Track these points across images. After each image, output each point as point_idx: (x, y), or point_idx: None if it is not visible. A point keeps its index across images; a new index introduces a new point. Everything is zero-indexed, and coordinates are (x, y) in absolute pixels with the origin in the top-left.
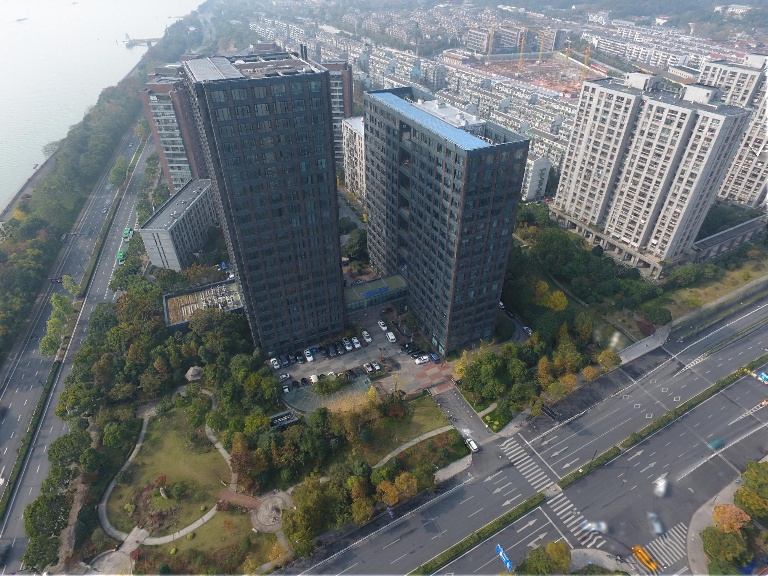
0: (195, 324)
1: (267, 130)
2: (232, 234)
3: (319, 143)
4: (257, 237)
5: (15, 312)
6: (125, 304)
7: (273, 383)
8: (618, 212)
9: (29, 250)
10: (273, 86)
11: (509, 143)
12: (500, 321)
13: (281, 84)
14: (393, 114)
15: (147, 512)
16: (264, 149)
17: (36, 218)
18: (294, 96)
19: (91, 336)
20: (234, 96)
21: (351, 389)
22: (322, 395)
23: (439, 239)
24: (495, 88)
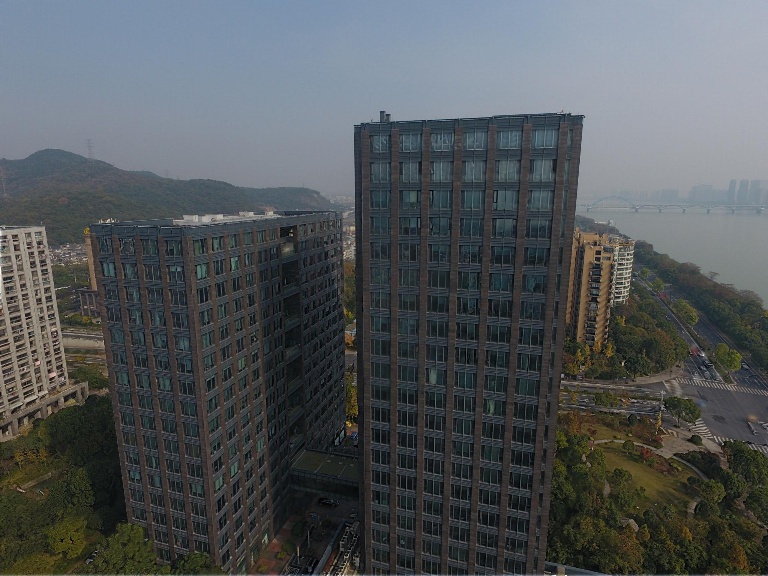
0: None
1: None
2: None
3: None
4: None
5: None
6: None
7: None
8: (0, 380)
9: None
10: None
11: None
12: None
13: None
14: (269, 226)
15: (658, 458)
16: None
17: None
18: None
19: None
20: None
21: None
22: None
23: None
24: None
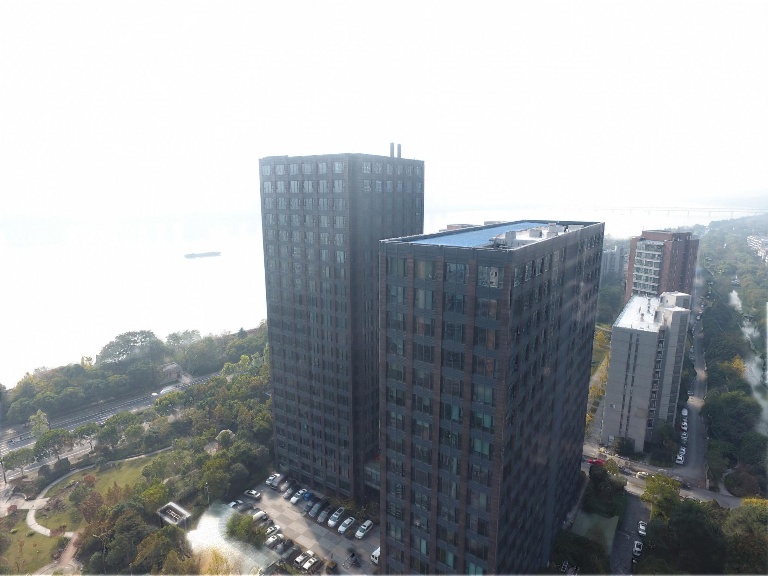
0: None
1: (297, 208)
2: None
3: (339, 232)
4: (281, 318)
5: (252, 346)
6: (268, 363)
7: (211, 476)
8: None
9: None
10: (304, 164)
11: (460, 246)
12: None
13: (311, 163)
14: None
15: None
16: (293, 226)
17: None
18: (320, 176)
19: None
20: (277, 171)
21: (246, 552)
22: (226, 531)
23: None
24: None
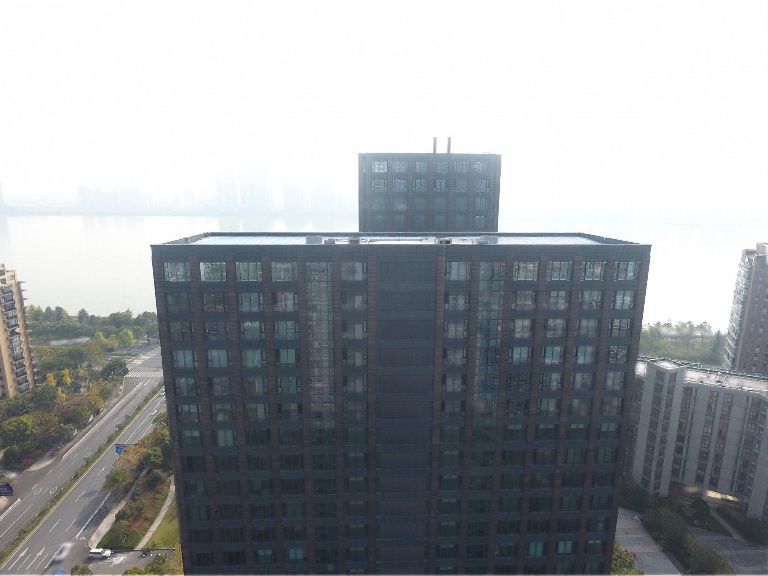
0: None
1: None
2: None
3: None
4: None
5: None
6: None
7: None
8: None
9: None
10: None
11: None
12: None
13: None
14: None
15: None
16: None
17: None
18: None
19: None
20: None
21: None
22: None
23: None
24: None
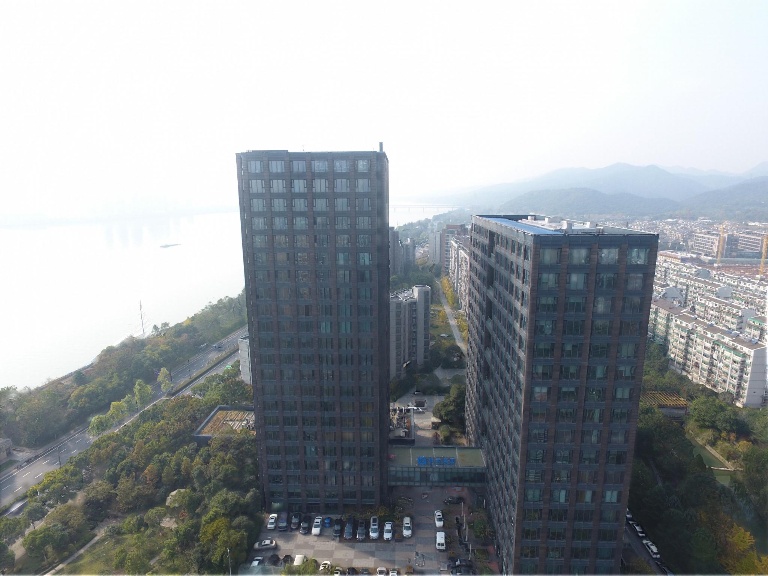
0: (215, 439)
1: (302, 209)
2: (251, 327)
3: (363, 233)
4: (276, 336)
5: (106, 390)
6: (173, 401)
7: (230, 541)
8: None
9: (162, 345)
10: (314, 161)
11: (614, 234)
12: (635, 575)
13: (324, 160)
14: (485, 226)
15: None
16: (296, 230)
17: (192, 325)
18: (337, 174)
19: (131, 426)
20: (271, 168)
21: None
22: None
23: (510, 385)
24: (714, 278)
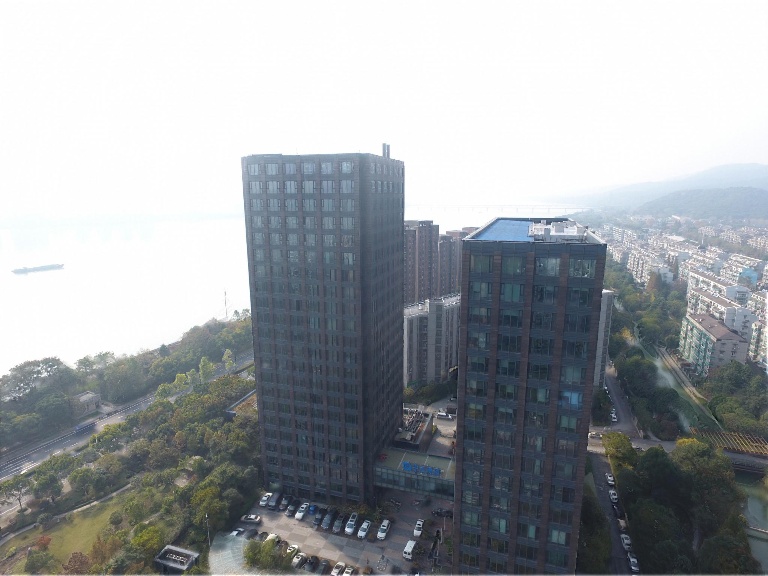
0: (237, 417)
1: (294, 209)
2: None
3: (347, 233)
4: (272, 327)
5: (180, 363)
6: None
7: (210, 508)
8: None
9: (237, 329)
10: (304, 164)
11: (553, 242)
12: None
13: (312, 162)
14: None
15: (8, 567)
16: (289, 229)
17: None
18: (323, 176)
19: None
20: (267, 171)
21: None
22: (246, 562)
23: None
24: None
